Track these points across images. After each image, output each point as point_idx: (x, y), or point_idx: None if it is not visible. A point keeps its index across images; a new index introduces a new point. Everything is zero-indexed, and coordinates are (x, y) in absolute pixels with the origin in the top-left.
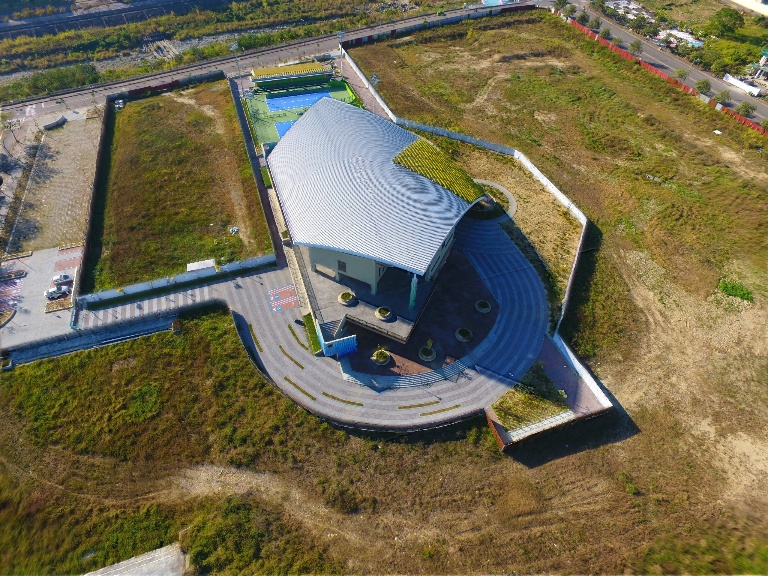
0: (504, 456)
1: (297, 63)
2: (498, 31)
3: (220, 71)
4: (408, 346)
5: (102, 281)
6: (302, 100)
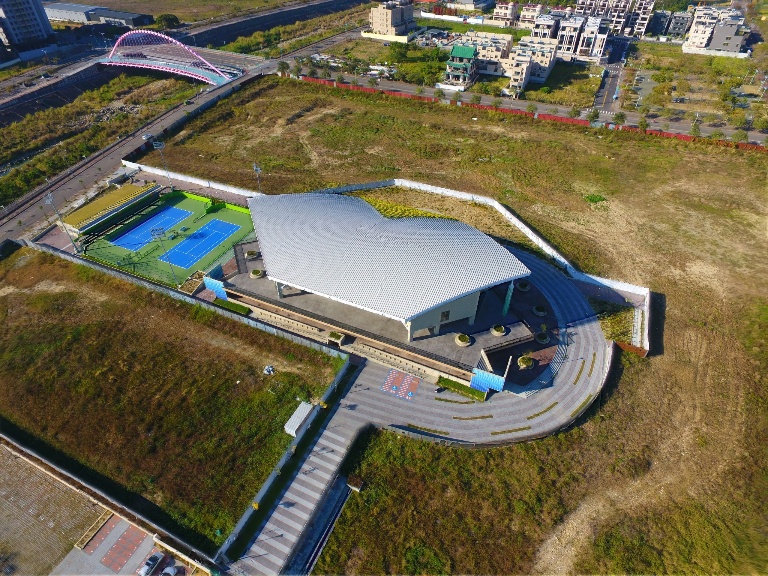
0: (648, 359)
1: (95, 195)
2: (255, 102)
3: (5, 241)
4: (525, 343)
5: (204, 523)
6: (155, 225)
